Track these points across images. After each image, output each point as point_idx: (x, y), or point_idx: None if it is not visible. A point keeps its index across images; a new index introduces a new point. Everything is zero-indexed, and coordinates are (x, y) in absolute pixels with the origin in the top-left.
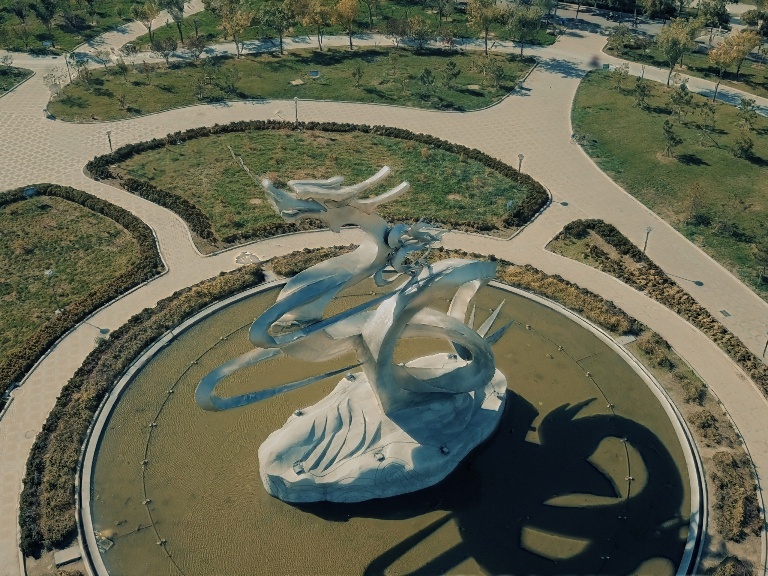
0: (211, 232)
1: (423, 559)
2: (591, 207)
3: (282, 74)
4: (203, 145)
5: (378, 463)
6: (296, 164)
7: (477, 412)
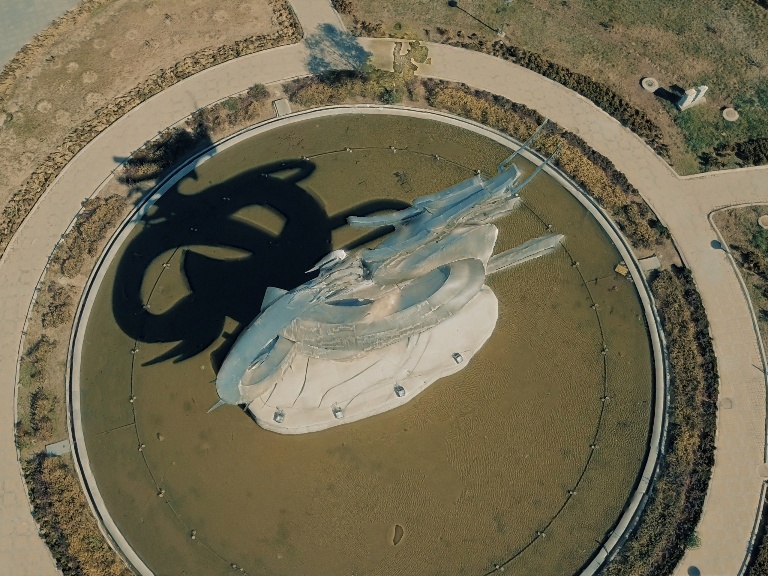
0: None
1: None
2: None
3: None
4: None
5: None
6: None
7: None
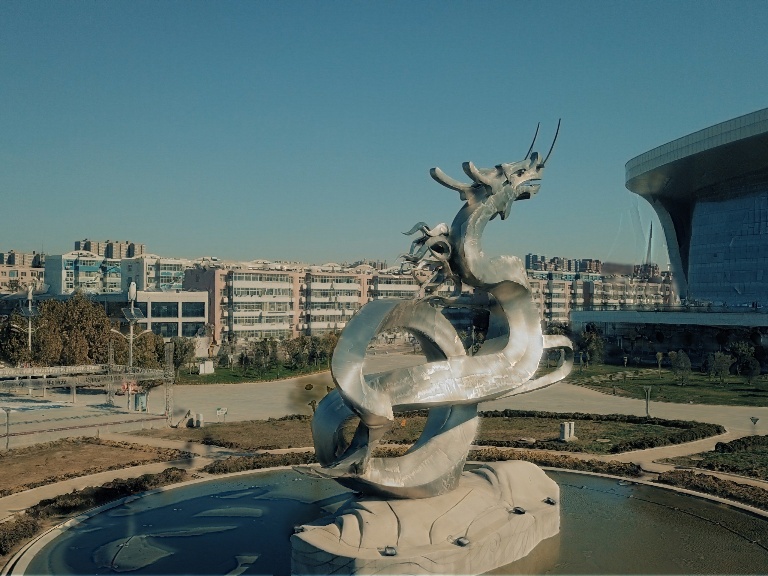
0: None
1: None
2: None
3: None
4: None
5: None
6: None
7: None
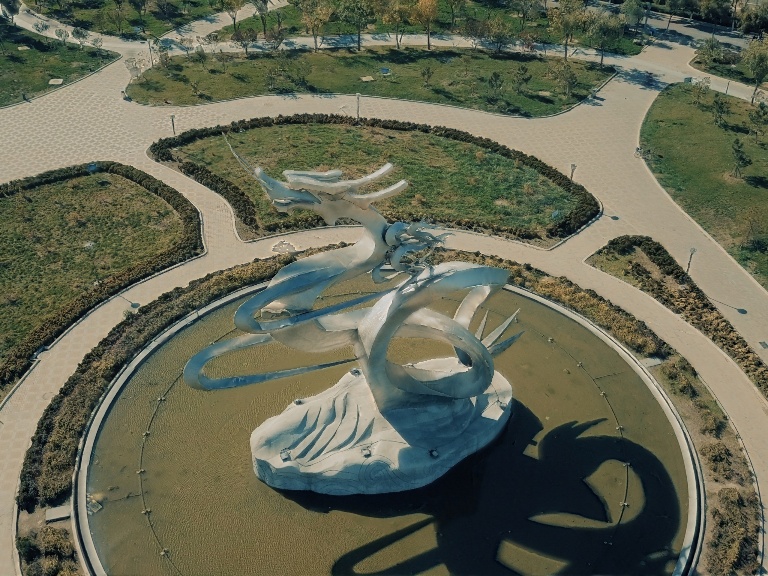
0: (255, 219)
1: (394, 559)
2: (642, 223)
3: (354, 70)
4: (264, 134)
5: (364, 459)
6: (350, 159)
7: (476, 419)
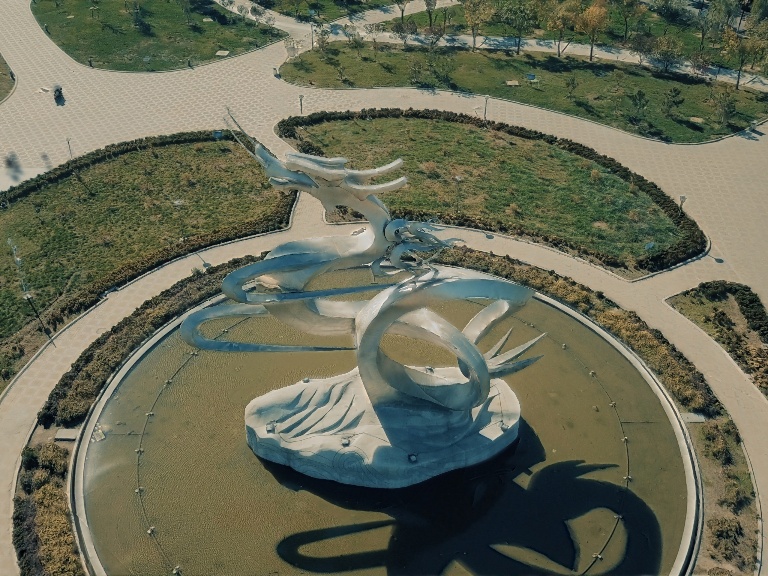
0: None
1: (340, 550)
2: (748, 271)
3: (503, 73)
4: (388, 125)
5: (341, 447)
6: (461, 159)
7: (472, 435)
